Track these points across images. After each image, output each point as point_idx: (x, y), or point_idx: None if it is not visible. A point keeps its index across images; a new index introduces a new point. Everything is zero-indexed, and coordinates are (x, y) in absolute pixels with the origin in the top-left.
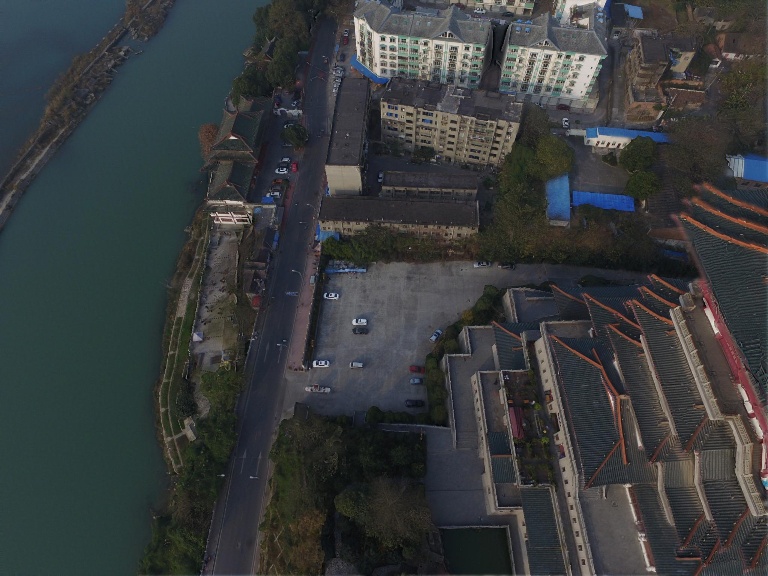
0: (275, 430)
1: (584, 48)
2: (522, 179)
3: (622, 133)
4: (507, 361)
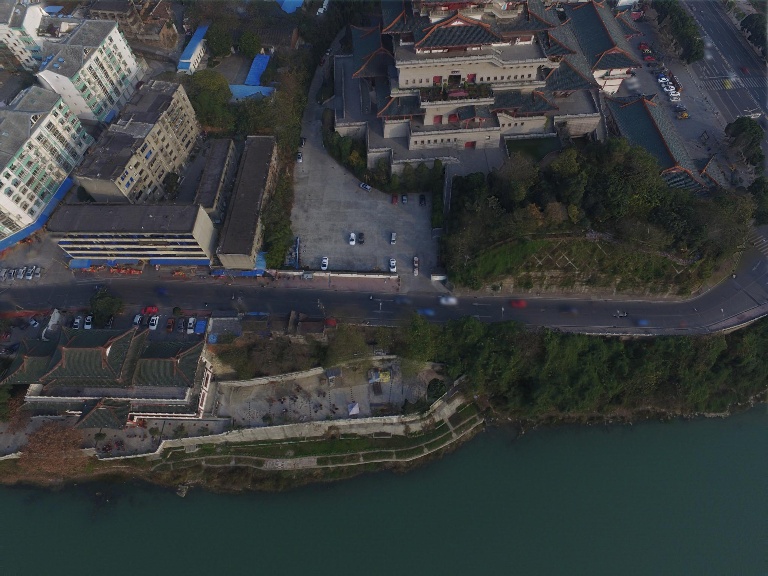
0: (453, 295)
1: (102, 32)
2: (226, 110)
3: (192, 47)
4: (408, 110)
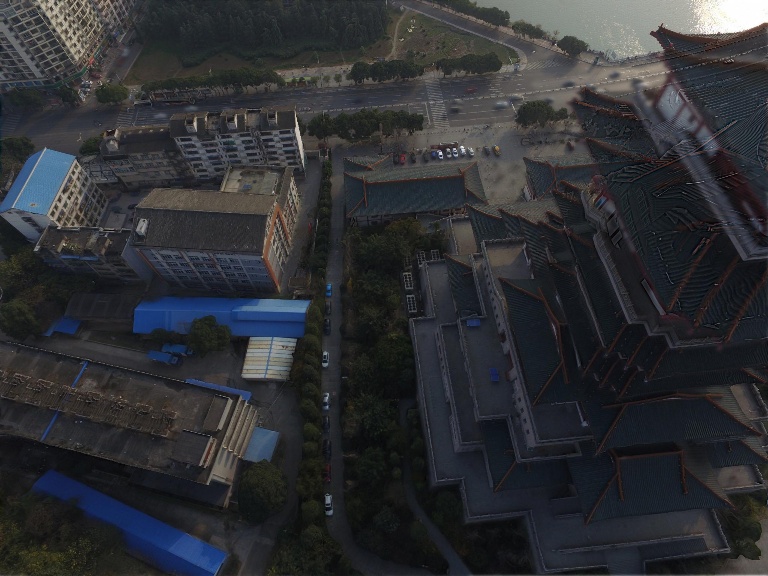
0: None
1: None
2: None
3: None
4: None
